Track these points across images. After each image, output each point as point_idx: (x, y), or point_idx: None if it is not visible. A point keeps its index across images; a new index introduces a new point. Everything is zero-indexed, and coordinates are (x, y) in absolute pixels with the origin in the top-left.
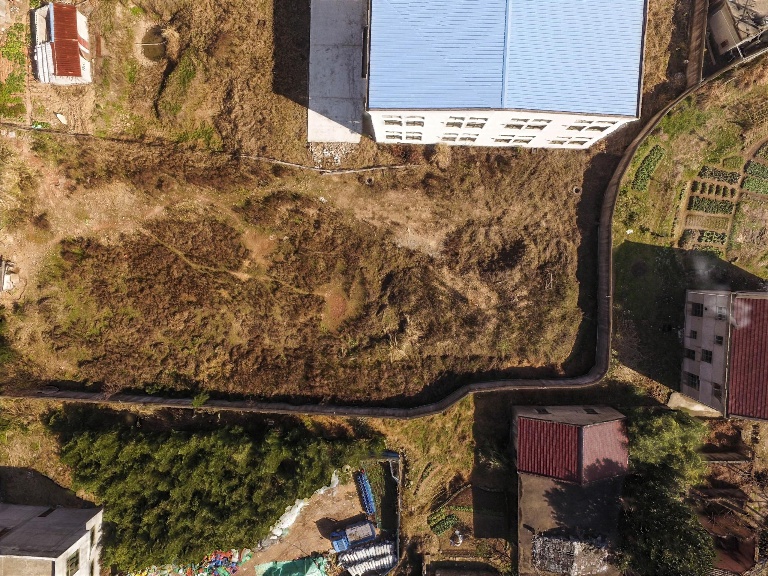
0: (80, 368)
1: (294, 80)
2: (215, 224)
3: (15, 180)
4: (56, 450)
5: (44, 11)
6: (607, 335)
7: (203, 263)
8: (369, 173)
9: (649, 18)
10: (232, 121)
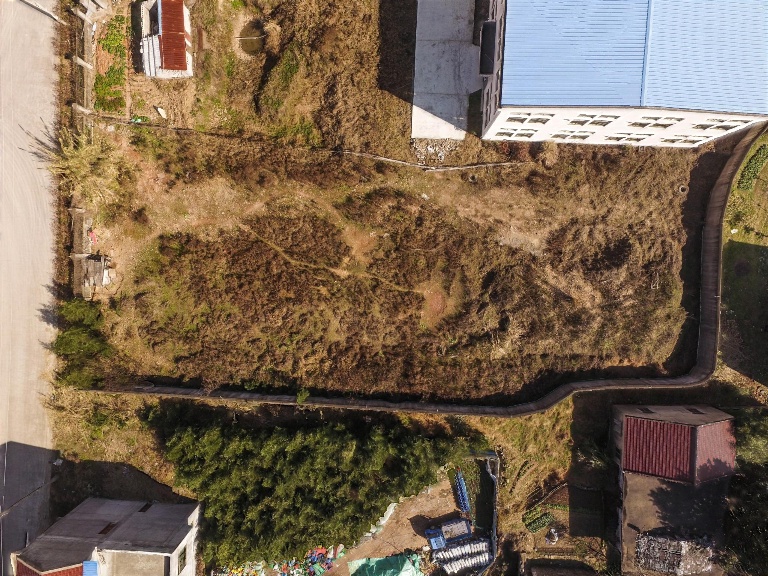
0: (178, 364)
1: (399, 75)
2: (316, 220)
3: (114, 174)
4: (152, 445)
5: (150, 4)
6: (714, 335)
7: (303, 259)
8: (473, 170)
9: None
10: (334, 116)
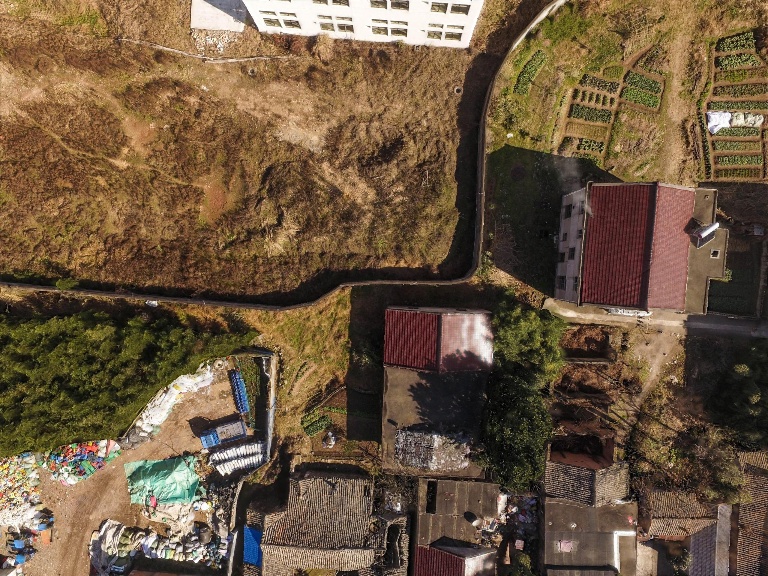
0: None
1: None
2: (93, 108)
3: None
4: None
5: None
6: (479, 232)
7: (80, 147)
8: (252, 63)
9: None
10: (115, 4)
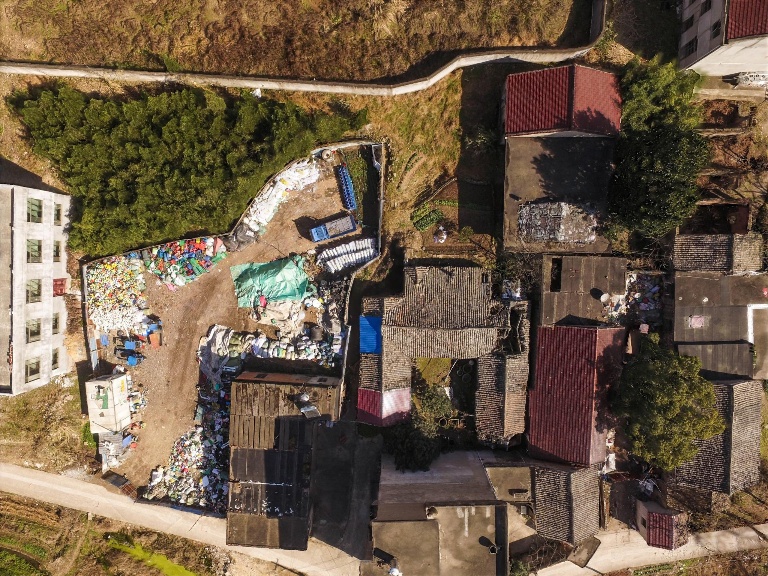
0: (46, 42)
1: None
2: None
3: None
4: (21, 133)
5: None
6: None
7: None
8: None
9: None
10: None
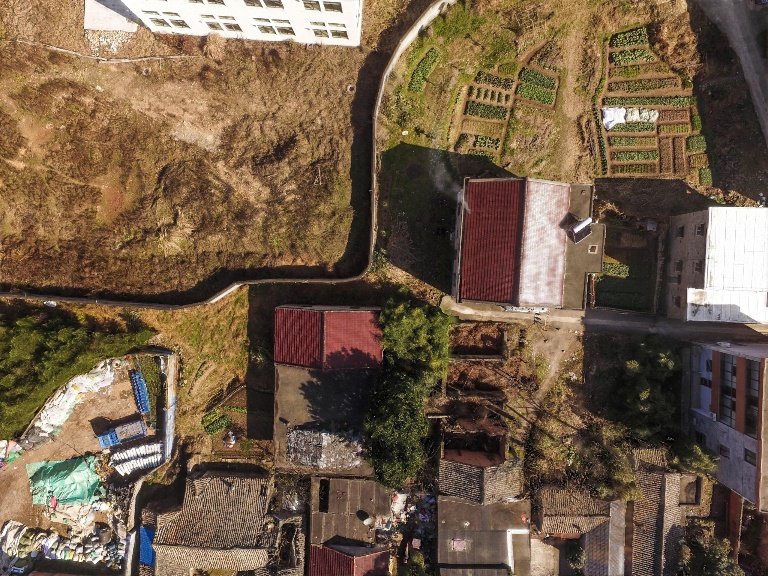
0: None
1: None
2: None
3: None
4: None
5: None
6: None
7: None
8: (145, 63)
9: None
10: (10, 6)
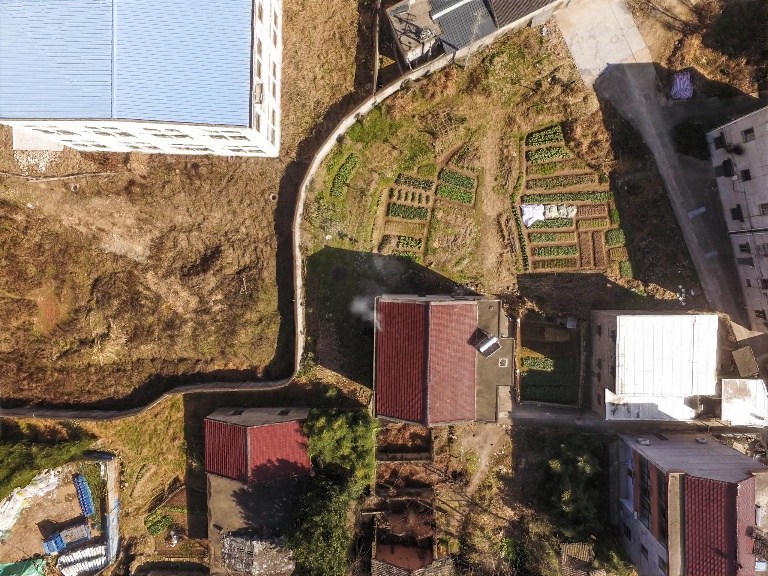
0: None
1: None
2: None
3: None
4: None
5: None
6: None
7: None
8: (73, 180)
9: (334, 31)
10: None
